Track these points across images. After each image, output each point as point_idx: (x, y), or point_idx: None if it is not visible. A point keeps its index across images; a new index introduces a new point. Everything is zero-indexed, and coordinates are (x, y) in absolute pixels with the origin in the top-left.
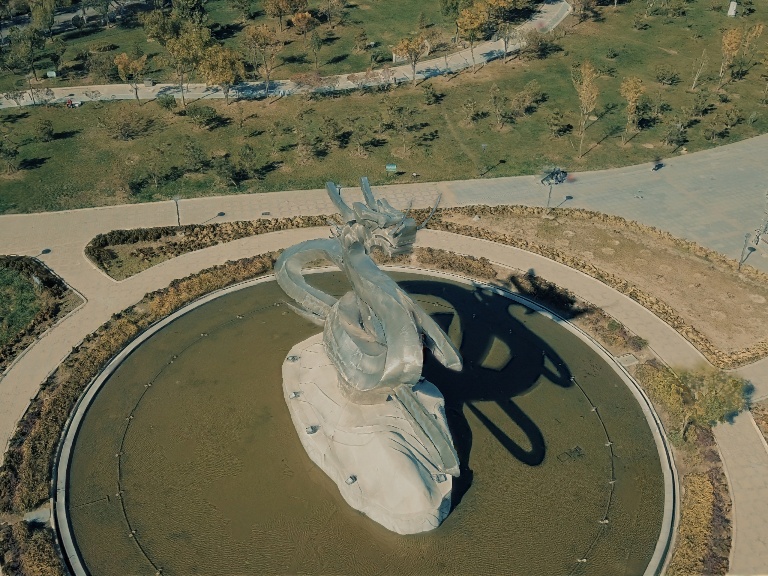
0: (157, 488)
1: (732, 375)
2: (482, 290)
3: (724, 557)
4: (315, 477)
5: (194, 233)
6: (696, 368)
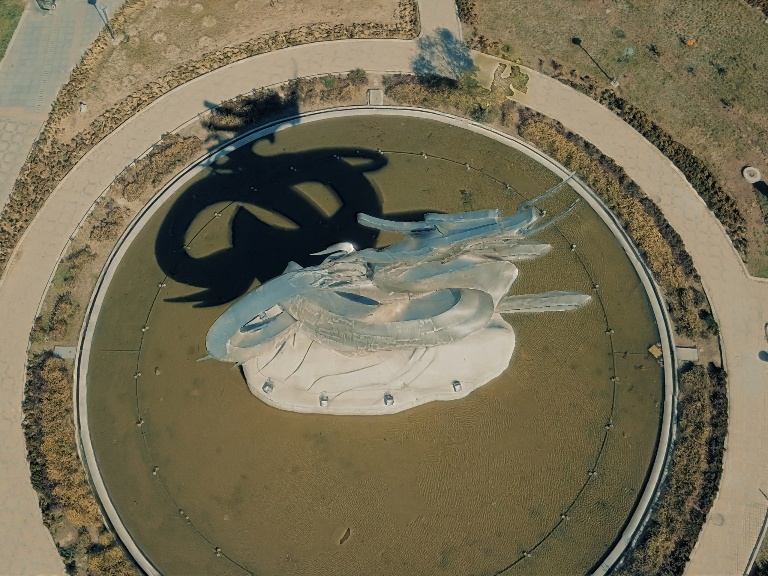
0: (378, 569)
1: (427, 35)
2: (216, 163)
3: (601, 156)
4: (400, 417)
5: None
6: (408, 54)
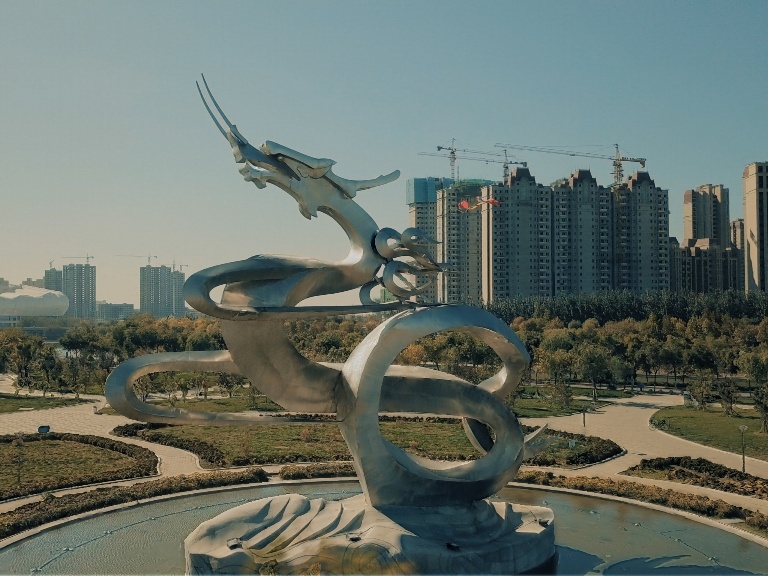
0: None
1: None
2: None
3: None
4: None
5: (750, 483)
6: None
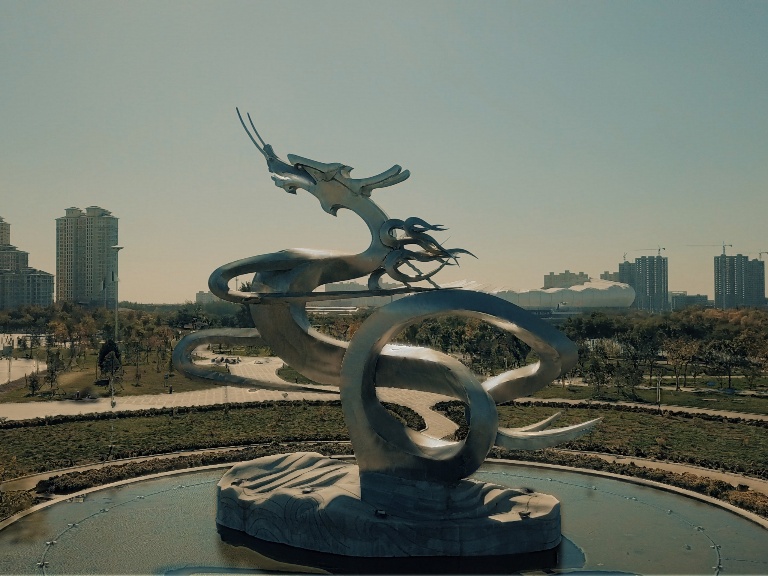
0: None
1: None
2: None
3: None
4: None
5: None
6: None
